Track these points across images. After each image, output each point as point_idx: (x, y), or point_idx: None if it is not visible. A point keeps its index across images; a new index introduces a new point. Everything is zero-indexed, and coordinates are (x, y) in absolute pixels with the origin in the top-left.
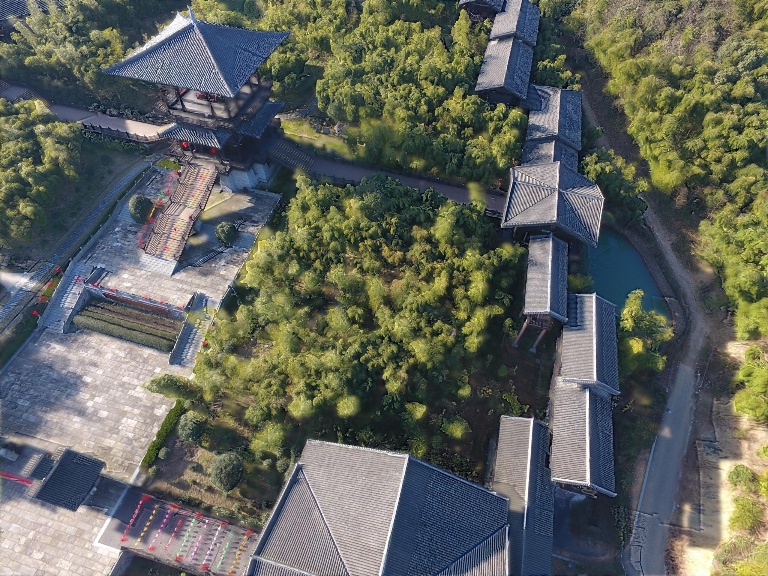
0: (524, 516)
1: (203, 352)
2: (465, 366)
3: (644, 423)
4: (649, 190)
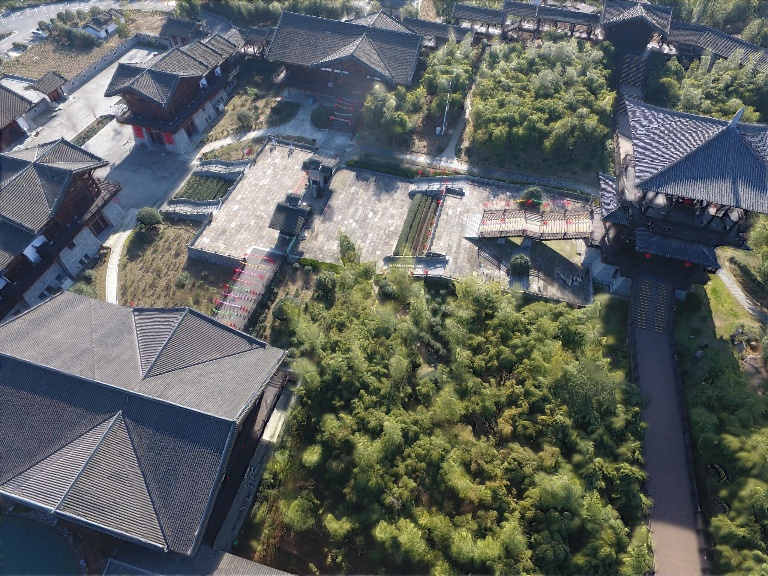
0: None
1: (383, 270)
2: (364, 527)
3: None
4: None
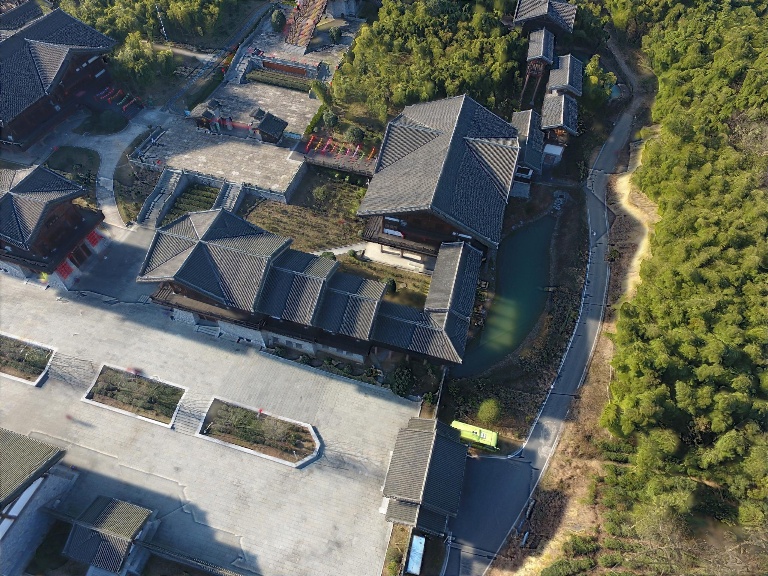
0: (526, 141)
1: None
2: None
3: (599, 135)
4: (613, 34)
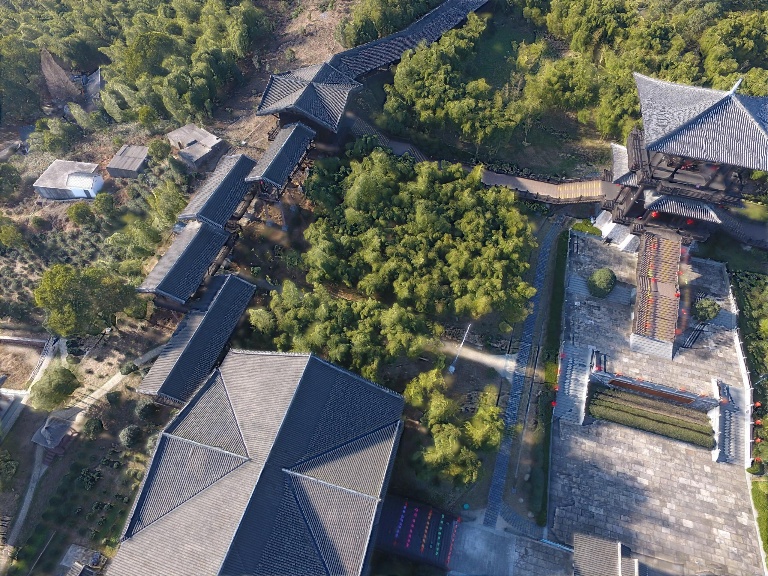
0: None
1: None
2: None
3: None
4: None
